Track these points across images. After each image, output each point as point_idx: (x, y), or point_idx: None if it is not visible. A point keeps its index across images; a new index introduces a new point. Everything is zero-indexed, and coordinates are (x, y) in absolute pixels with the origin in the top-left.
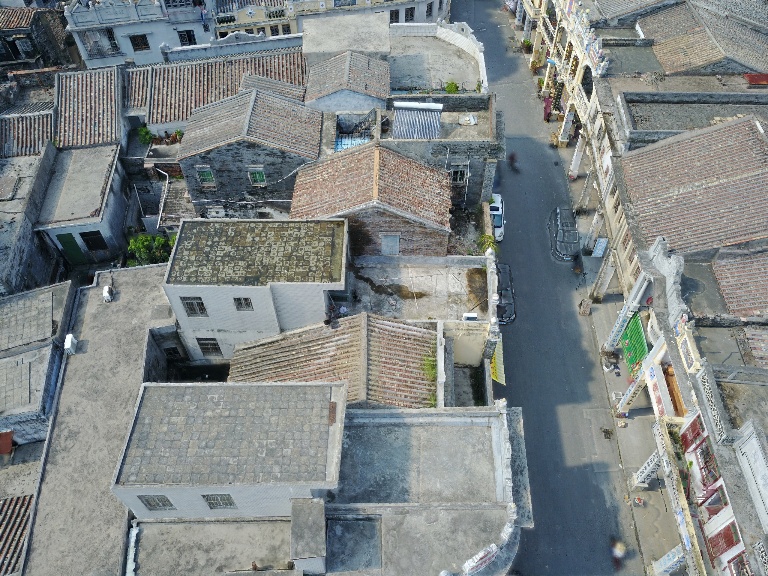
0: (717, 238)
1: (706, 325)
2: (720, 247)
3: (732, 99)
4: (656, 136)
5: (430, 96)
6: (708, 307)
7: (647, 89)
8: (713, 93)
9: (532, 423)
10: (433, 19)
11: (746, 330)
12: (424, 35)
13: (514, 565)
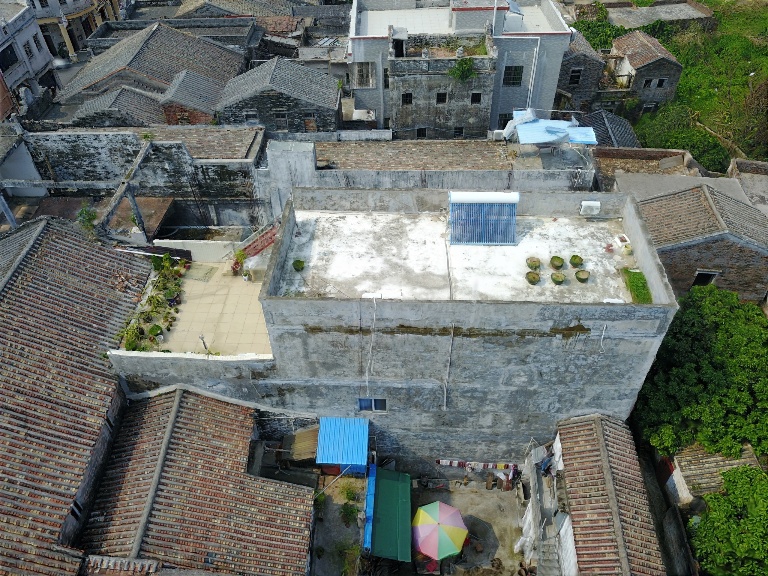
0: None
1: (40, 130)
2: (81, 91)
3: (186, 24)
4: (107, 43)
5: None
6: None
7: None
8: (169, 20)
9: None
10: (69, 7)
11: (60, 129)
12: (8, 2)
13: None
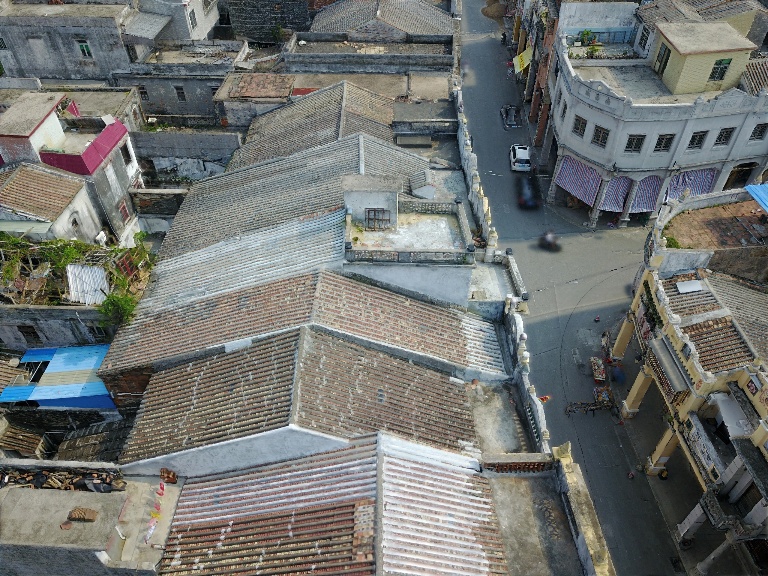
0: (423, 4)
1: None
2: None
3: (364, 59)
4: (436, 38)
5: (608, 2)
6: (434, 1)
7: (417, 90)
8: (381, 54)
9: (491, 80)
10: None
11: None
12: None
13: (501, 51)
